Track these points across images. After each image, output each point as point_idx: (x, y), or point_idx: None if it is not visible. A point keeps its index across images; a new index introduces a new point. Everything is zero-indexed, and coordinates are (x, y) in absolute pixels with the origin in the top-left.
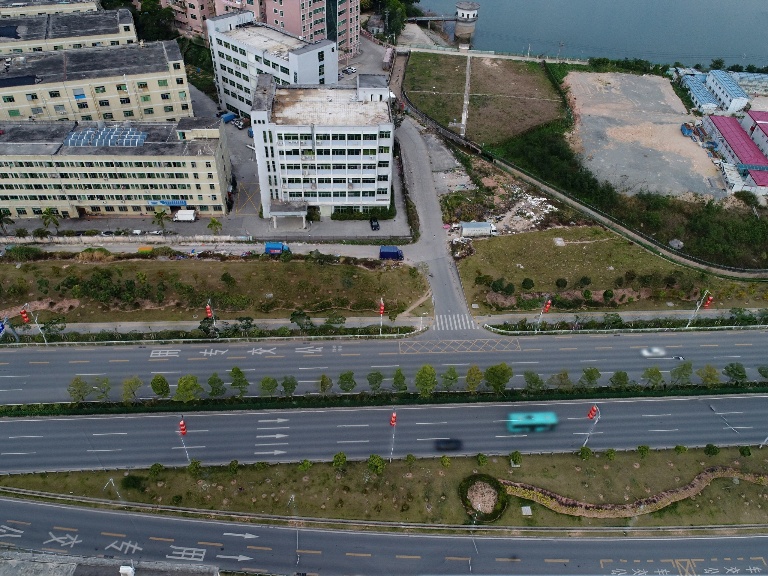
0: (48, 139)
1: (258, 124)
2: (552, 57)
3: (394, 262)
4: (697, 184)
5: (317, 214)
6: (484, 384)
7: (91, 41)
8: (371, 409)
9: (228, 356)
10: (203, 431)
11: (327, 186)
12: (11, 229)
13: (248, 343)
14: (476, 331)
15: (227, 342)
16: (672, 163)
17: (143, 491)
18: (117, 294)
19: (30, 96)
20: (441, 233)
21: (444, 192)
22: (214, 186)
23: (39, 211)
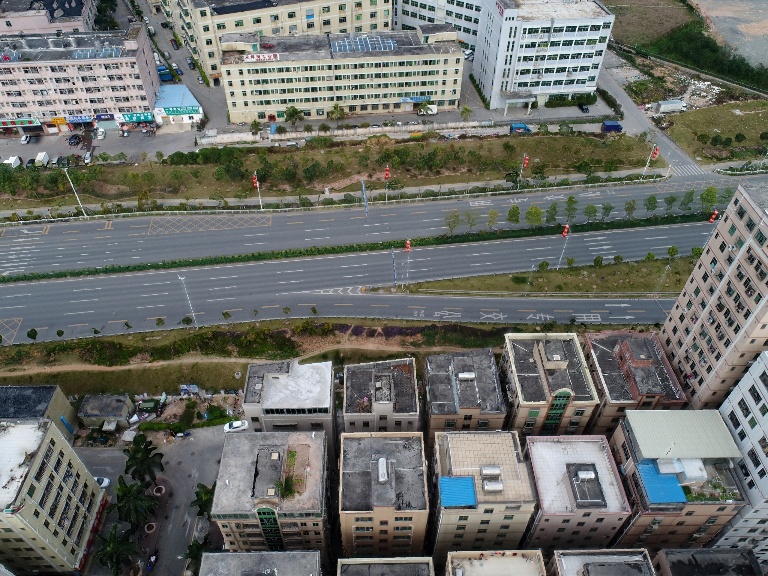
0: (315, 49)
1: (508, 21)
2: None
3: (615, 134)
4: None
5: (536, 102)
6: None
7: None
8: (663, 227)
9: (531, 202)
10: (547, 248)
11: (550, 76)
12: (290, 128)
13: (540, 193)
14: (709, 175)
15: (524, 193)
16: None
17: (532, 284)
18: None
19: (273, 17)
20: (639, 112)
21: (624, 82)
22: (457, 81)
23: (308, 113)
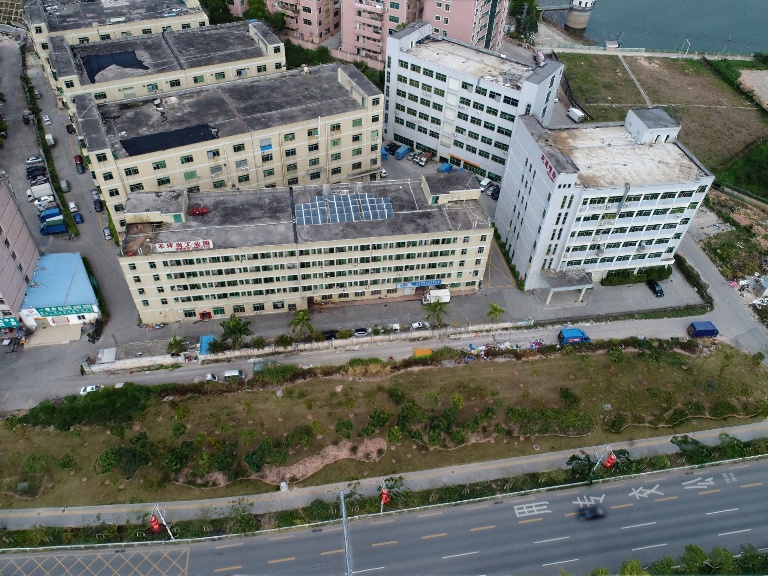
0: (271, 216)
1: (562, 188)
2: (708, 52)
3: (708, 340)
4: None
5: None
6: None
7: (235, 68)
8: None
9: (611, 505)
10: None
11: (613, 251)
12: None
13: (622, 481)
14: None
15: (598, 483)
16: None
17: None
18: None
19: (211, 153)
20: (732, 293)
21: (701, 237)
22: (480, 261)
23: (260, 306)
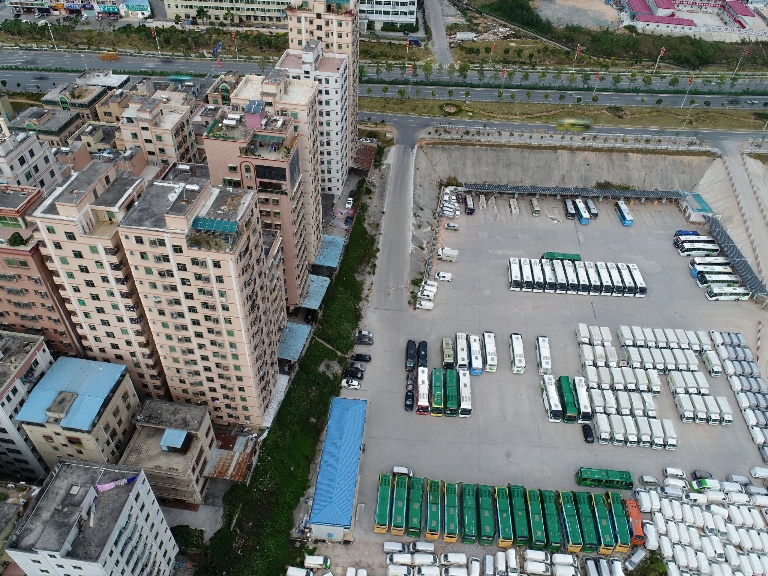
0: None
1: None
2: None
3: (416, 47)
4: (603, 22)
5: (373, 26)
6: (457, 78)
7: None
8: (400, 86)
9: None
10: None
11: (380, 7)
12: None
13: None
14: None
15: None
16: (592, 14)
17: None
18: (270, 43)
19: None
20: (444, 39)
21: (449, 24)
22: None
23: (218, 17)
